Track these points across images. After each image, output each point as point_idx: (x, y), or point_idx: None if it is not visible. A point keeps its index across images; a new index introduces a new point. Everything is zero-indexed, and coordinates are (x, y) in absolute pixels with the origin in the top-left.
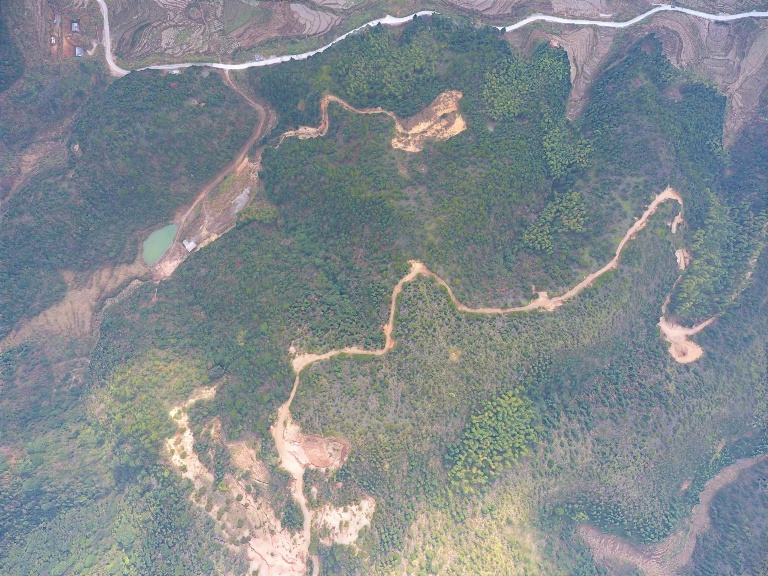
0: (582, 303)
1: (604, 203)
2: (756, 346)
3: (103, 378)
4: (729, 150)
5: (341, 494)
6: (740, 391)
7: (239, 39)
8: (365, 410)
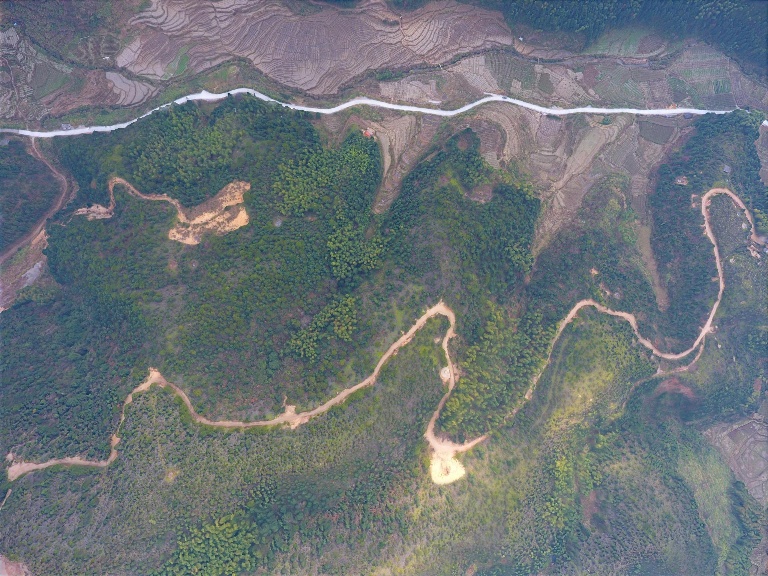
0: (327, 422)
1: (378, 311)
2: (518, 471)
3: None
4: (541, 253)
5: None
6: (491, 520)
7: (49, 106)
8: (57, 534)
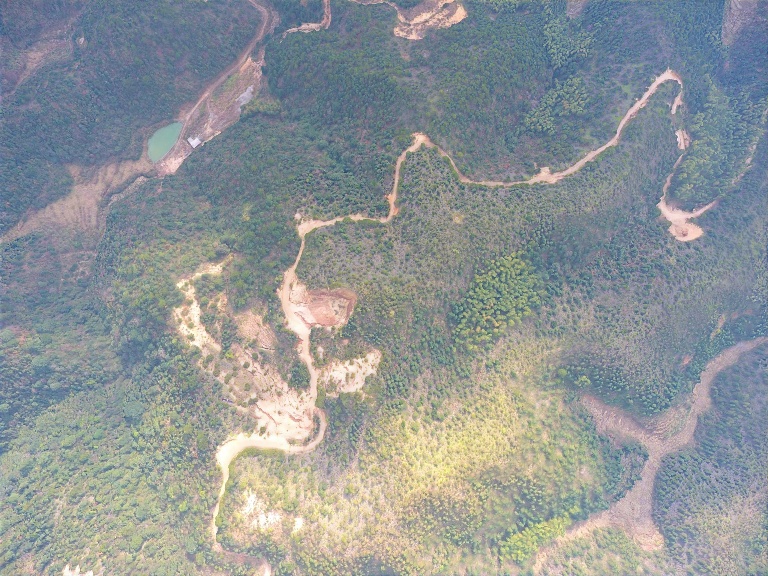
0: (583, 176)
1: (605, 87)
2: (756, 225)
3: (110, 265)
4: None
5: (347, 349)
6: (740, 266)
7: None
8: (370, 265)
